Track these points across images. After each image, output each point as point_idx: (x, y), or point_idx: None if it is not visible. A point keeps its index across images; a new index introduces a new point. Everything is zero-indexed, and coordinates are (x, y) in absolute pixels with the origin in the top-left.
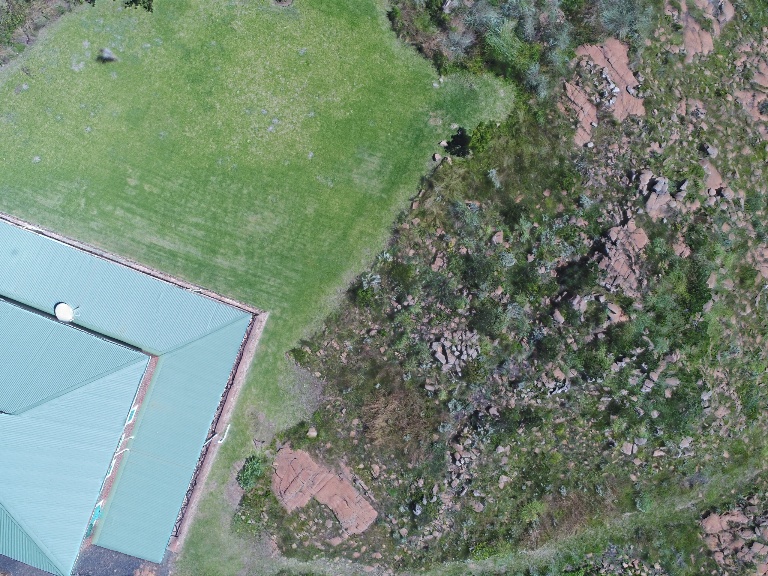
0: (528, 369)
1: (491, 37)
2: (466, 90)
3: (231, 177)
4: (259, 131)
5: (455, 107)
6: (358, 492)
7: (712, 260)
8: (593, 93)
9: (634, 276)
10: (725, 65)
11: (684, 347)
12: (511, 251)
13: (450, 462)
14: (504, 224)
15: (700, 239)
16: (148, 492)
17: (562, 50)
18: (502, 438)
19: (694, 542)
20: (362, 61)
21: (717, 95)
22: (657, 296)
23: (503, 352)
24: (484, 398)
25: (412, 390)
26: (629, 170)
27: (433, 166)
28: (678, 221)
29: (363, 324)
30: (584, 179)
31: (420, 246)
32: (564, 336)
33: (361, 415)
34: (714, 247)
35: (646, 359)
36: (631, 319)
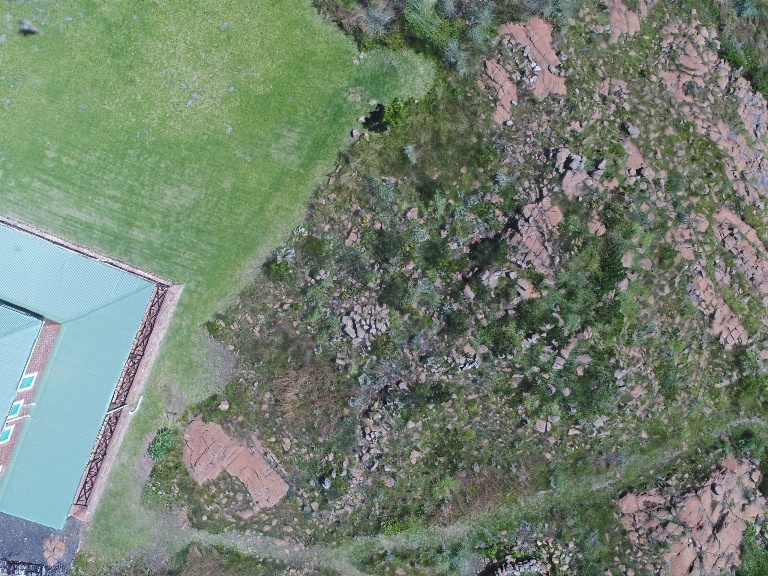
0: (439, 344)
1: (410, 14)
2: (386, 67)
3: (149, 150)
4: (178, 105)
5: (374, 84)
6: (269, 465)
7: (628, 239)
8: (514, 72)
9: (546, 253)
10: (651, 46)
11: (596, 325)
12: (425, 227)
13: (361, 436)
14: (419, 200)
15: (615, 218)
16: (50, 459)
17: (483, 28)
18: (412, 413)
19: (609, 521)
20: (283, 37)
21: (641, 76)
22: (570, 274)
23: (413, 327)
24: (395, 373)
25: (323, 364)
26: (547, 148)
27: (351, 142)
28: (594, 200)
29: (277, 298)
30: (501, 157)
31: (335, 221)
32: (474, 312)
33: (273, 388)
34: (631, 226)
35: (555, 336)
36: (542, 296)
